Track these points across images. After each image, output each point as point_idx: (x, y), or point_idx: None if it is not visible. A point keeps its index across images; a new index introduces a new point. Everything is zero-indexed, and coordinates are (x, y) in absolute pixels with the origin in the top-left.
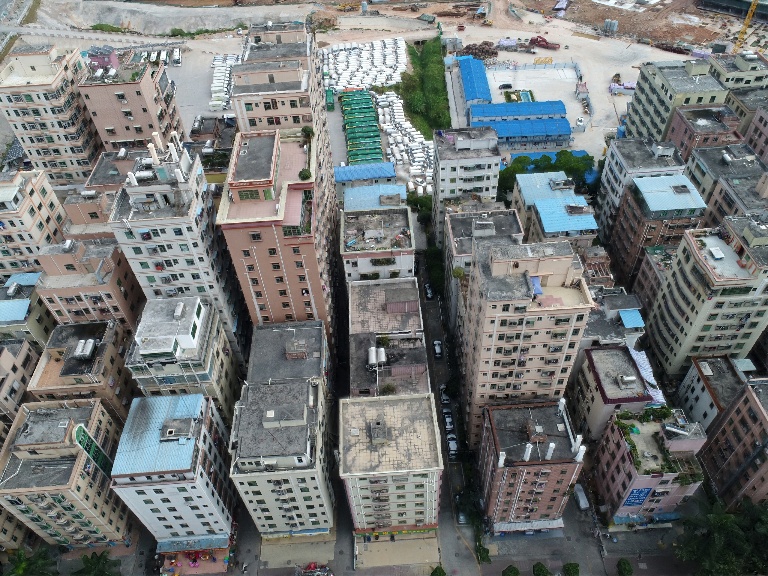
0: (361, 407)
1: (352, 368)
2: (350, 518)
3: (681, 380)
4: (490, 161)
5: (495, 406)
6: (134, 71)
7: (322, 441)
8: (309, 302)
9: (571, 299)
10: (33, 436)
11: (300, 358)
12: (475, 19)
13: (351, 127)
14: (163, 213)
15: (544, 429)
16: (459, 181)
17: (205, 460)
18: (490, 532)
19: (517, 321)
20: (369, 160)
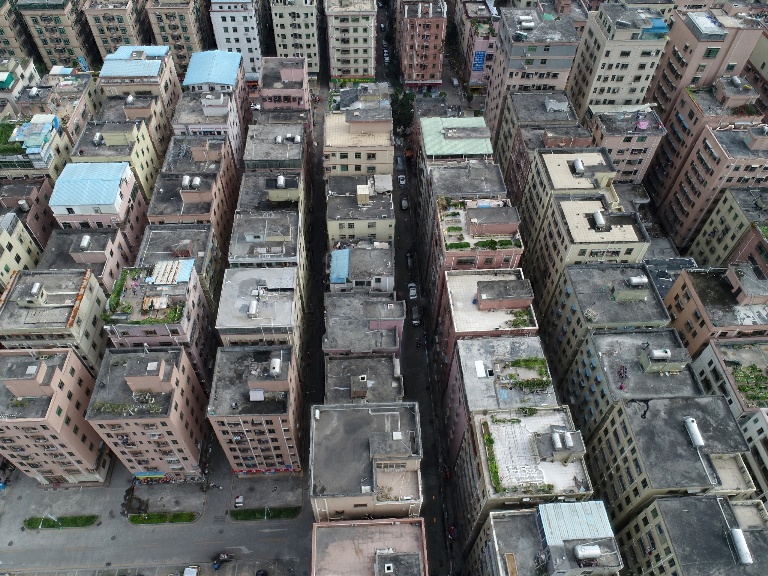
0: None
1: None
2: (328, 81)
3: None
4: None
5: (407, 2)
6: None
7: (316, 8)
8: None
9: None
10: None
11: None
12: None
13: None
14: None
15: (429, 5)
16: None
17: (255, 12)
18: (404, 91)
19: None
20: None
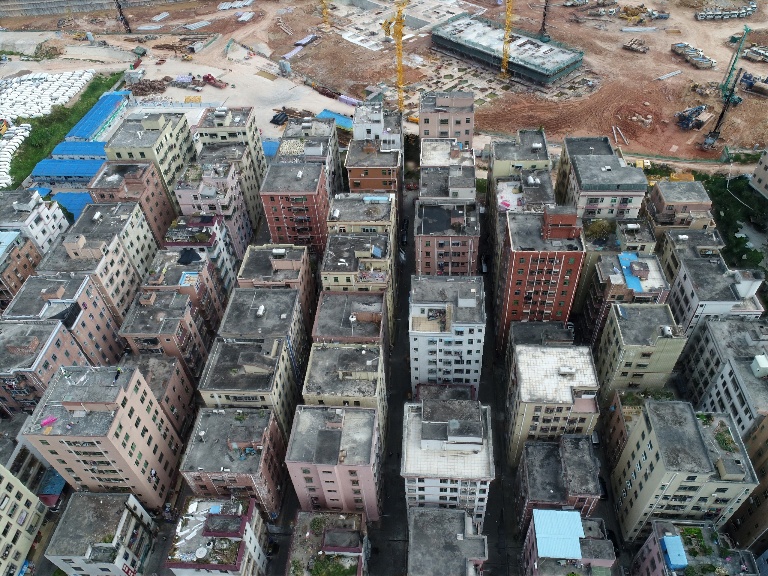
0: None
1: None
2: None
3: None
4: None
5: None
6: None
7: None
8: None
9: None
10: None
11: None
12: (187, 53)
13: None
14: None
15: None
16: None
17: None
18: None
19: None
20: None
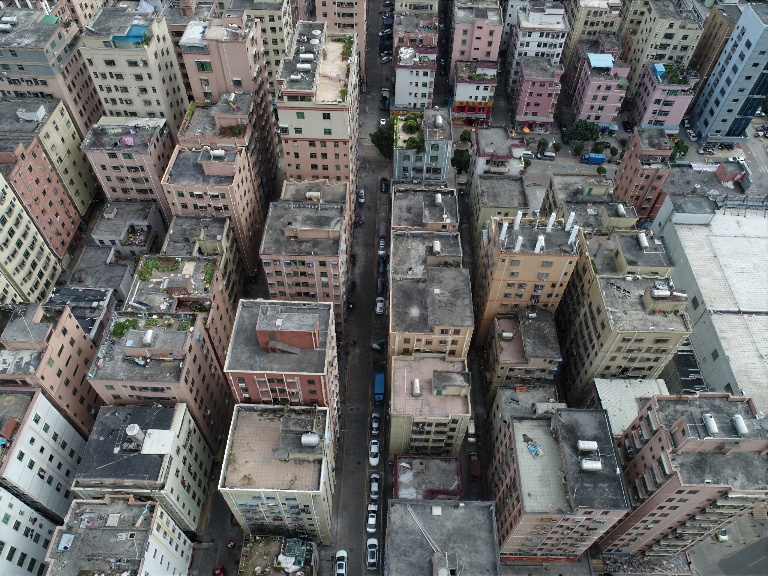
0: None
1: None
2: None
3: None
4: None
5: None
6: None
7: None
8: None
9: None
10: None
11: None
12: None
13: None
14: None
15: (37, 2)
16: None
17: None
18: None
19: None
20: None
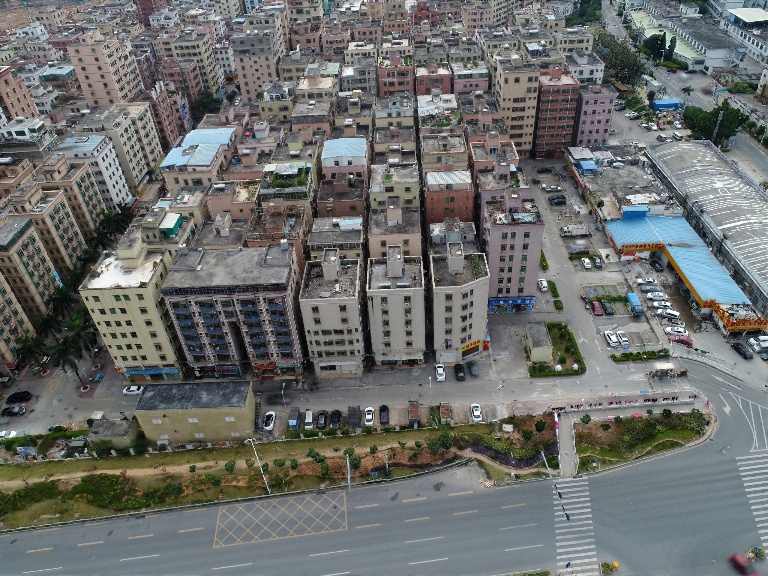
0: None
1: None
2: None
3: None
4: None
5: None
6: None
7: None
8: None
9: None
10: (53, 162)
11: (66, 131)
12: None
13: None
14: None
15: None
16: None
17: None
18: None
19: None
20: None
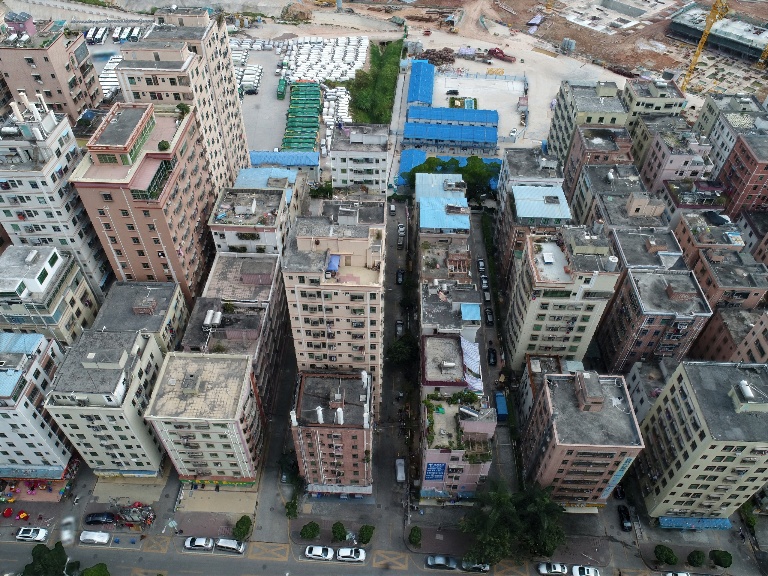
0: (186, 361)
1: (189, 327)
2: None
3: (521, 376)
4: (377, 156)
5: (310, 373)
6: (47, 39)
7: (143, 387)
8: (167, 265)
9: (368, 279)
10: None
11: (147, 314)
12: (444, 26)
13: (293, 116)
14: (24, 167)
15: (342, 397)
16: (350, 172)
17: (34, 393)
18: (309, 493)
19: (315, 293)
20: (300, 148)
